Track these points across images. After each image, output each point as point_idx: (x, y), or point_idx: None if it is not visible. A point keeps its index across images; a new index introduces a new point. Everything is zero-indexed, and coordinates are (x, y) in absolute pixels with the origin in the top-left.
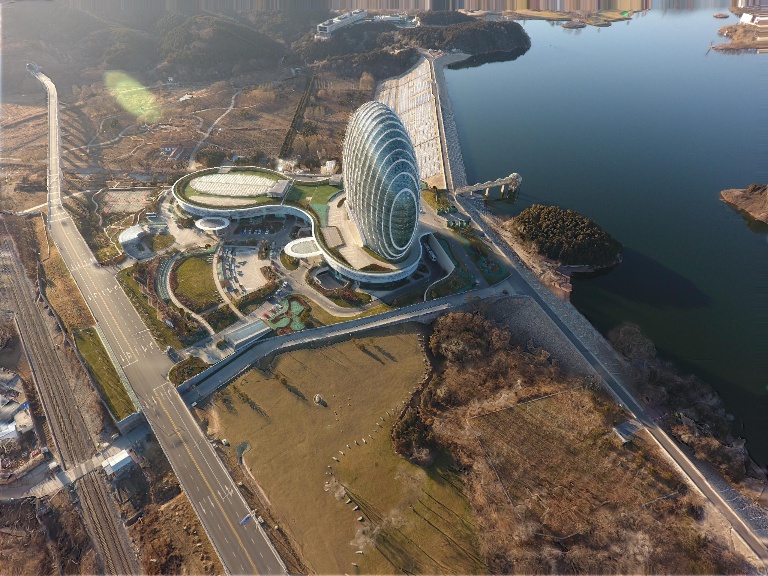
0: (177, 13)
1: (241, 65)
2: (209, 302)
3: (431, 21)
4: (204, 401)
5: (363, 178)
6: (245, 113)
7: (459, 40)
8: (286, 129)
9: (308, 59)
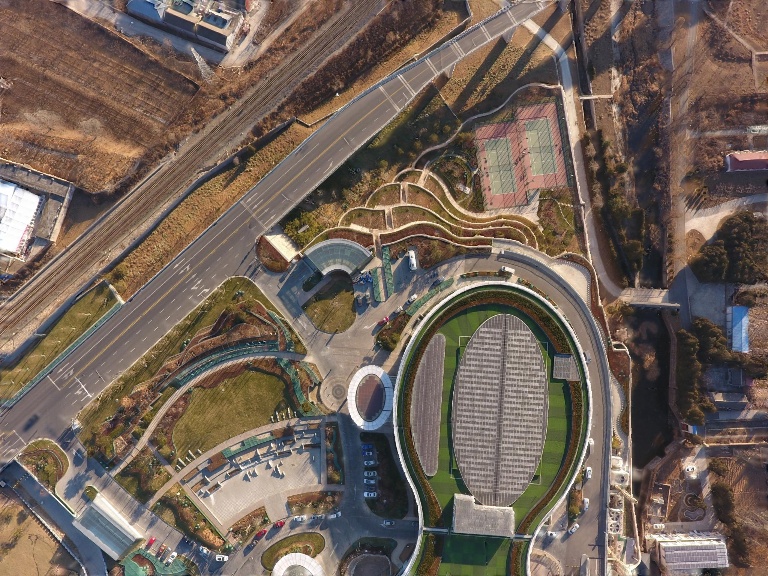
0: None
1: None
2: (170, 452)
3: None
4: (12, 492)
5: None
6: None
7: None
8: None
9: None
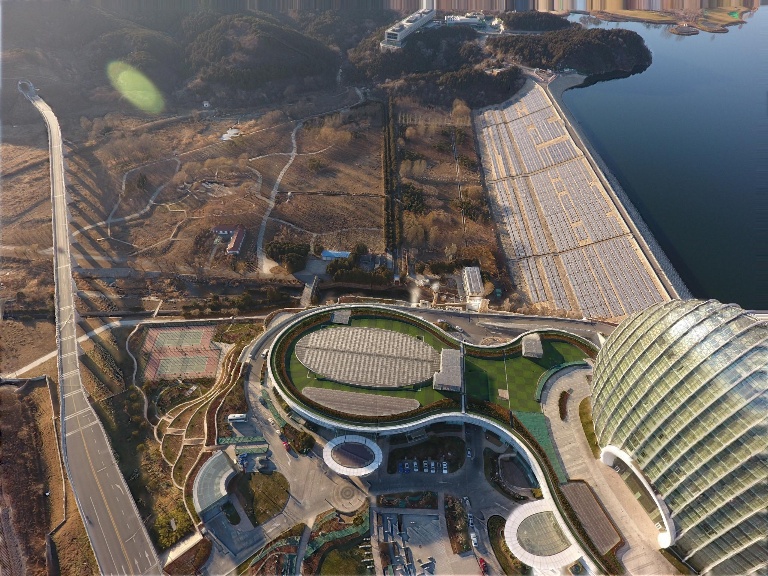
0: (206, 10)
1: (294, 84)
2: None
3: (518, 25)
4: None
5: (759, 501)
6: (317, 165)
7: (572, 57)
8: (379, 194)
9: (378, 77)
